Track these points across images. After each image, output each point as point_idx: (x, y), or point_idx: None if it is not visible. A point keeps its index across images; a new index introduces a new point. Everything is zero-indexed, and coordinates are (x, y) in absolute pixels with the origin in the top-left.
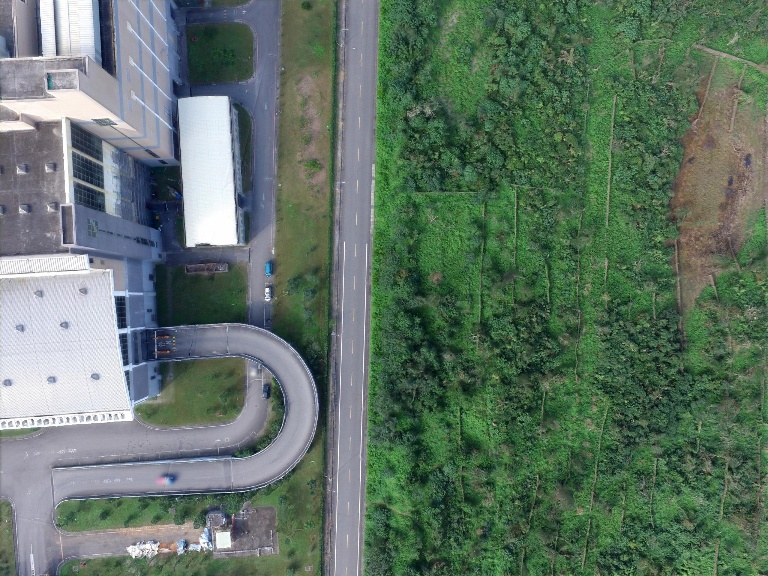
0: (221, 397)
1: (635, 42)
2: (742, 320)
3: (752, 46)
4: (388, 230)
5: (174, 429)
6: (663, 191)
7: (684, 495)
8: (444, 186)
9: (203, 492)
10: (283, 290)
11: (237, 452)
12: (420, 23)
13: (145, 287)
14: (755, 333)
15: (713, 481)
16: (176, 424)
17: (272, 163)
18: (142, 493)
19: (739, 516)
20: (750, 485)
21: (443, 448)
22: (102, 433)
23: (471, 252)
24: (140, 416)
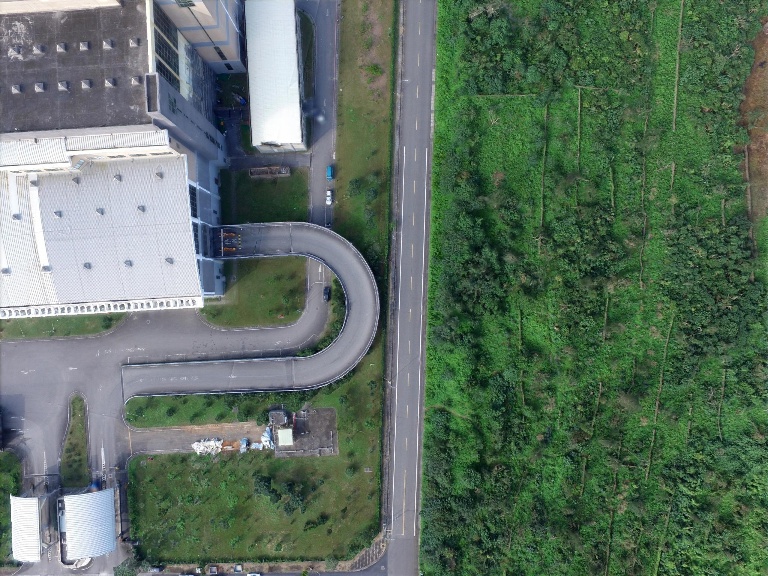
0: (284, 297)
1: None
2: None
3: None
4: (448, 134)
5: (237, 330)
6: (733, 94)
7: (754, 408)
8: (505, 89)
9: (266, 390)
10: (344, 194)
11: (299, 351)
12: None
13: (211, 188)
14: None
15: None
16: (239, 325)
17: (333, 69)
18: (207, 391)
19: None
20: None
21: (503, 354)
22: (169, 333)
23: (533, 155)
24: (205, 316)
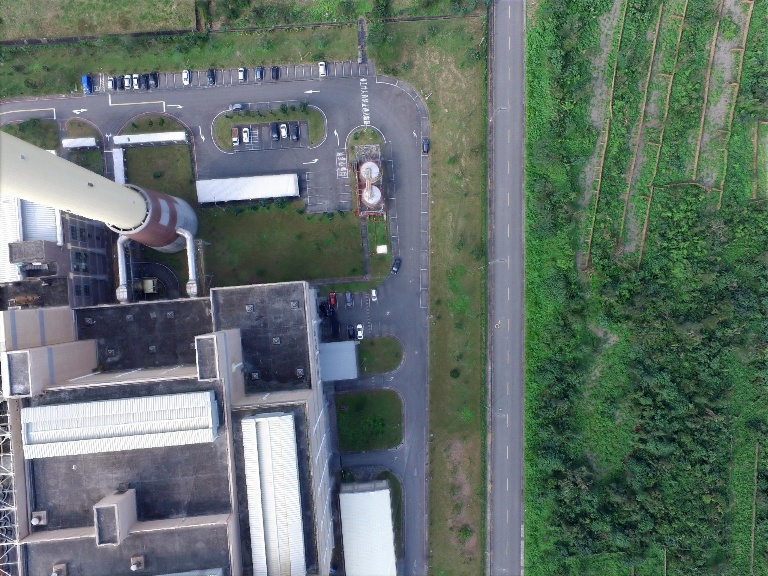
0: None
1: None
2: None
3: None
4: None
5: None
6: None
7: None
8: (594, 548)
9: None
10: None
11: None
12: None
13: None
14: None
15: None
16: None
17: (423, 529)
18: None
19: None
20: None
21: None
22: None
23: None
24: None
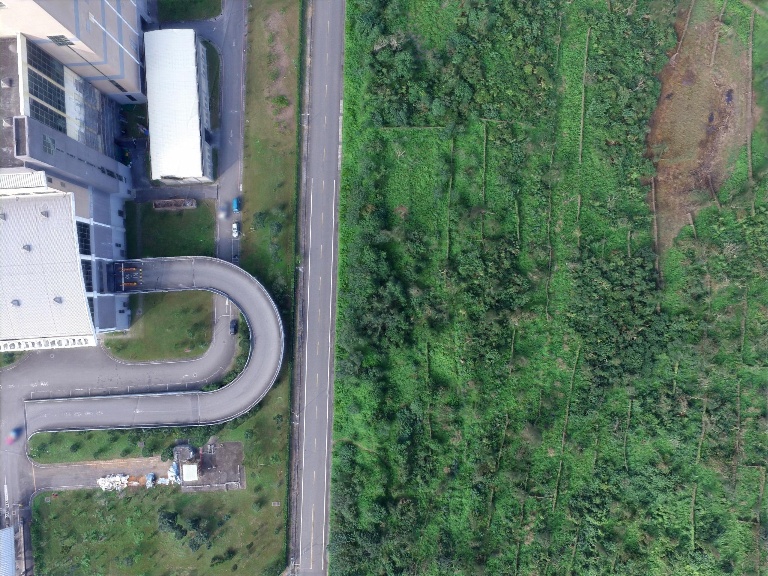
0: (188, 331)
1: None
2: (721, 258)
3: None
4: (356, 166)
5: (143, 364)
6: (639, 127)
7: (660, 438)
8: (412, 121)
9: (170, 425)
10: (250, 226)
11: (204, 386)
12: None
13: (113, 221)
14: (734, 271)
15: (690, 424)
16: (145, 359)
17: (240, 100)
18: (112, 426)
19: (716, 459)
20: (729, 428)
21: (411, 386)
22: (73, 367)
23: (439, 188)
24: (110, 350)
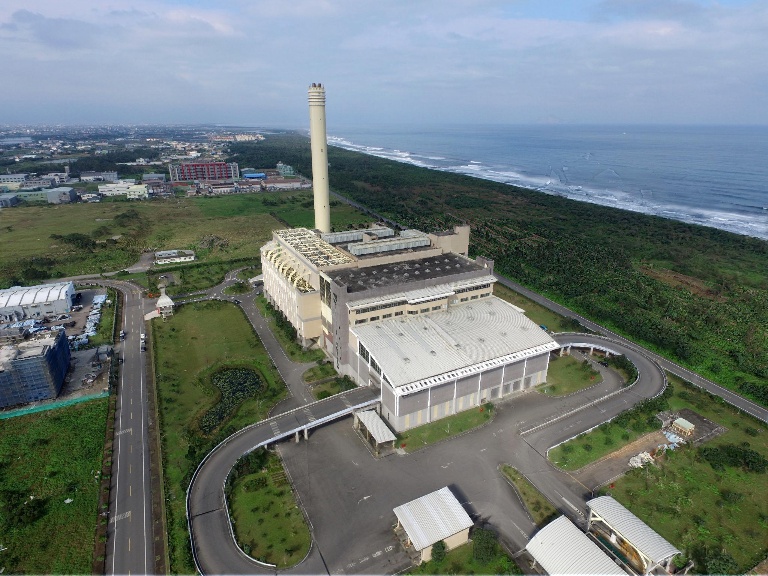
0: None
1: None
2: None
3: None
4: None
5: (574, 393)
6: None
7: None
8: None
9: None
10: None
11: (626, 383)
12: None
13: None
14: (767, 298)
15: None
16: None
17: None
18: None
19: None
20: None
21: (725, 359)
22: (533, 408)
23: None
24: (547, 391)
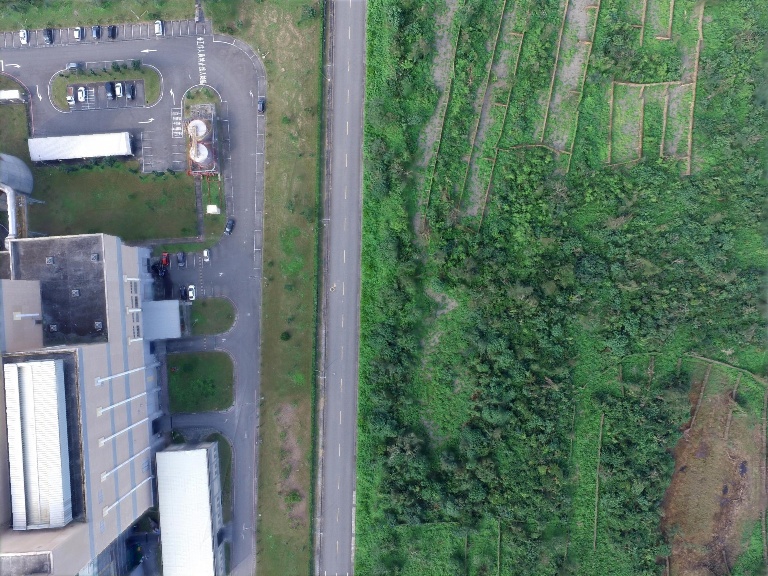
0: None
1: (623, 357)
2: None
3: (747, 353)
4: (369, 559)
5: None
6: (653, 509)
7: None
8: (425, 517)
9: None
10: None
11: None
12: (400, 350)
13: None
14: None
15: None
16: None
17: (252, 493)
18: None
19: None
20: None
21: None
22: None
23: None
24: None
